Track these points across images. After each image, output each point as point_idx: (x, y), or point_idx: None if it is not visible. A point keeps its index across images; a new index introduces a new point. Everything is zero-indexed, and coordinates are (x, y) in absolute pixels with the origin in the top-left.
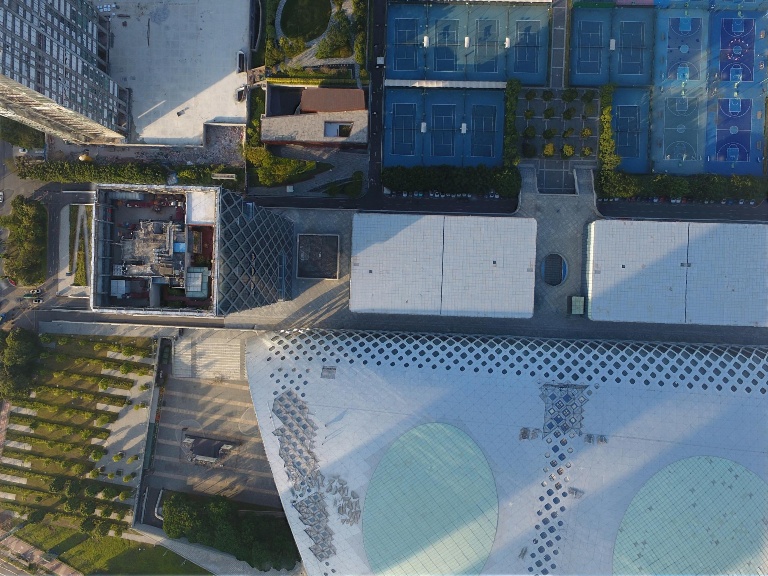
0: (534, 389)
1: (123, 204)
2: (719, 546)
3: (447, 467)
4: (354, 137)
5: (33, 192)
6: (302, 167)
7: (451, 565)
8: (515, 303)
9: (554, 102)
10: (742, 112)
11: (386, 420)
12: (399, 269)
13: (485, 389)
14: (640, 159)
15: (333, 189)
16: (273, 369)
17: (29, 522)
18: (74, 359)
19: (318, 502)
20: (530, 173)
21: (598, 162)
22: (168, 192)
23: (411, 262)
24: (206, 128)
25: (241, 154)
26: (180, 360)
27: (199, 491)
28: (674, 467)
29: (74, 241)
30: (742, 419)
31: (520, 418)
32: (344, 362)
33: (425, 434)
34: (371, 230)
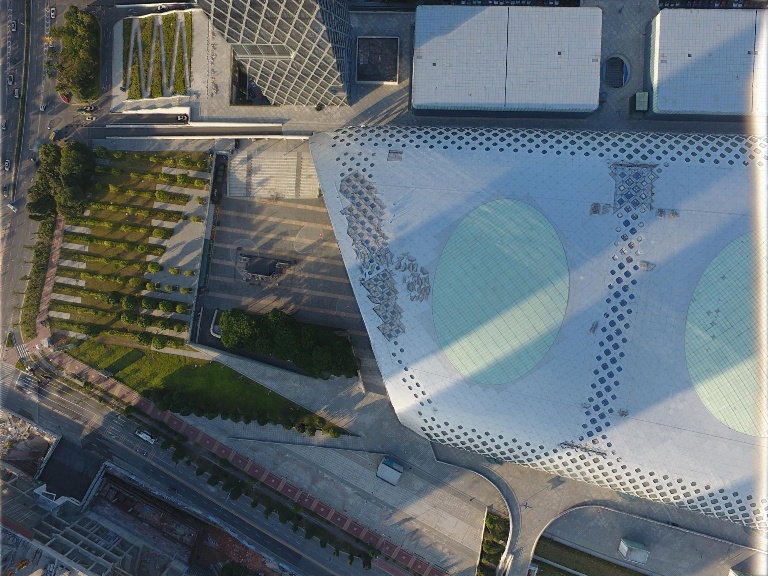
0: (603, 168)
1: None
2: None
3: (518, 241)
4: None
5: (86, 7)
6: None
7: (522, 339)
8: (580, 94)
9: None
10: None
11: (455, 198)
12: (463, 61)
13: (554, 168)
14: None
15: None
16: (339, 153)
17: (86, 333)
18: (128, 175)
19: (387, 280)
20: None
21: None
22: None
23: (475, 54)
24: None
25: None
26: (235, 177)
27: (254, 311)
28: (747, 237)
29: (128, 56)
30: None
31: (590, 194)
32: (410, 147)
33: (495, 210)
34: (434, 22)
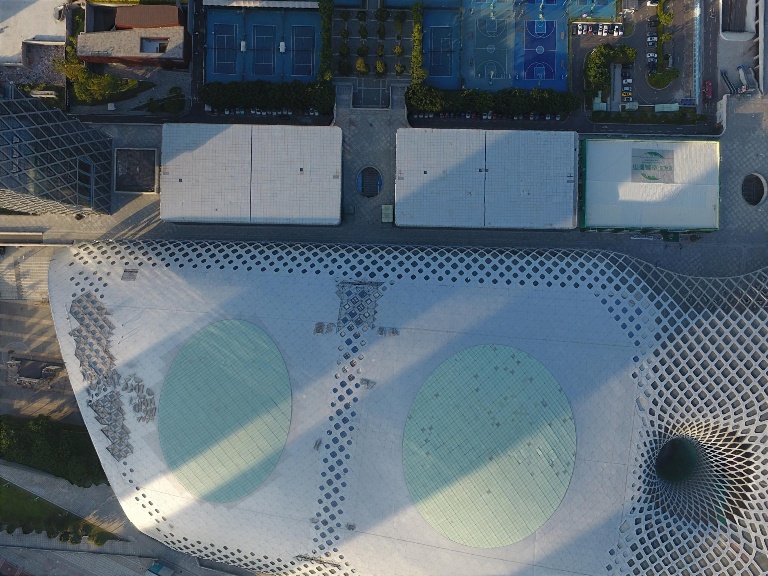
0: (331, 286)
1: None
2: (500, 428)
3: (241, 361)
4: (170, 53)
5: None
6: (124, 85)
7: (246, 458)
8: (322, 209)
9: (370, 23)
10: (547, 33)
11: (183, 318)
12: (208, 177)
13: (283, 287)
14: (453, 77)
15: (151, 104)
16: (74, 273)
17: None
18: None
19: (114, 401)
20: (347, 90)
21: None
22: None
23: (220, 170)
24: (27, 47)
25: None
26: (4, 281)
27: (27, 414)
28: (460, 355)
29: None
30: (527, 310)
31: (315, 313)
32: (147, 265)
33: (221, 330)
34: (180, 139)
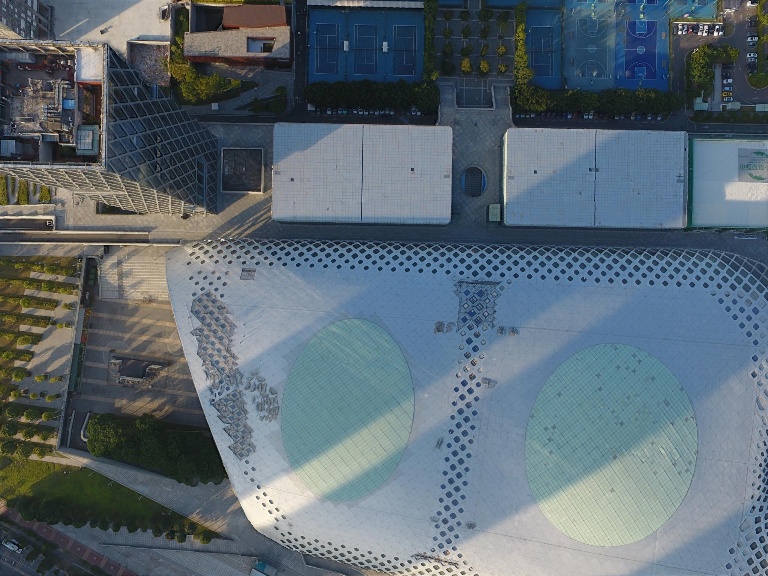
0: (449, 286)
1: (13, 65)
2: (624, 427)
3: (364, 361)
4: (276, 52)
5: None
6: (227, 85)
7: (369, 457)
8: (433, 209)
9: (472, 23)
10: (648, 33)
11: (304, 317)
12: (320, 177)
13: (401, 286)
14: (554, 77)
15: (257, 104)
16: (192, 272)
17: None
18: None
19: (237, 400)
20: (450, 90)
21: (515, 80)
22: (57, 50)
23: (331, 170)
24: (130, 47)
25: (167, 74)
26: (106, 280)
27: (127, 413)
28: (581, 354)
29: None
30: (645, 309)
31: (435, 313)
32: (264, 265)
33: (342, 330)
34: (292, 139)
